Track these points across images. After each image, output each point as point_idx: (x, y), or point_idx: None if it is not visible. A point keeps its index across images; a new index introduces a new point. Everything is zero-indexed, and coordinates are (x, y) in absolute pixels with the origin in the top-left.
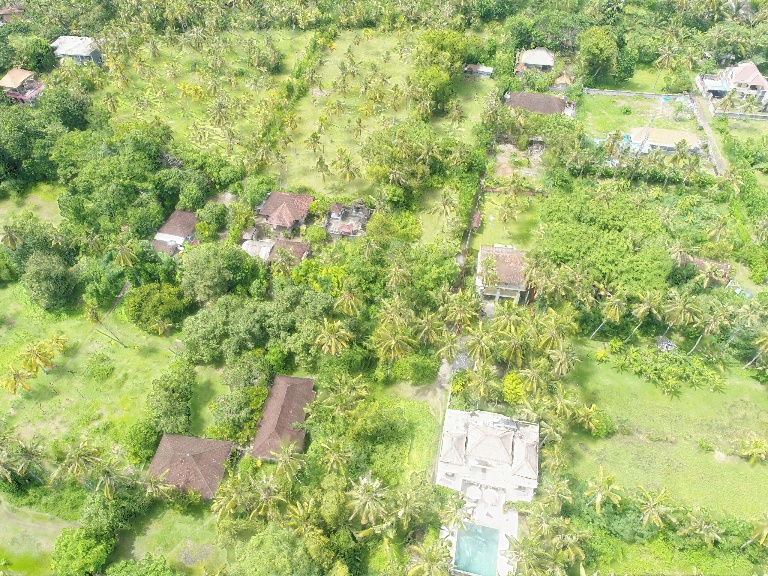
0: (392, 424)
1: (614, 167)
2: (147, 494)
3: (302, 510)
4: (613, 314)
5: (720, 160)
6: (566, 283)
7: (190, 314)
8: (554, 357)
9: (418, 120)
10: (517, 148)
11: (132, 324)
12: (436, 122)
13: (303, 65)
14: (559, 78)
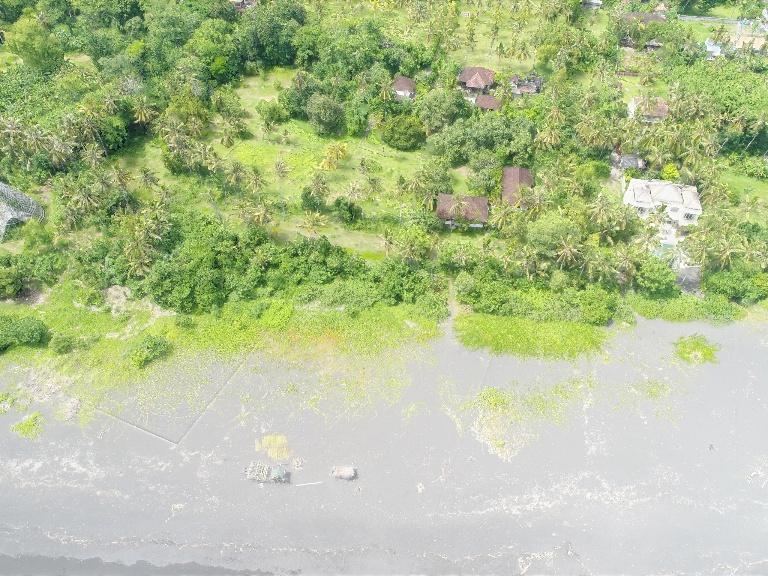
0: (594, 189)
1: (713, 60)
2: (453, 209)
3: (561, 211)
4: (738, 126)
5: None
6: (705, 106)
7: (425, 139)
8: (705, 144)
9: None
10: None
11: (383, 145)
12: None
13: None
14: (658, 6)
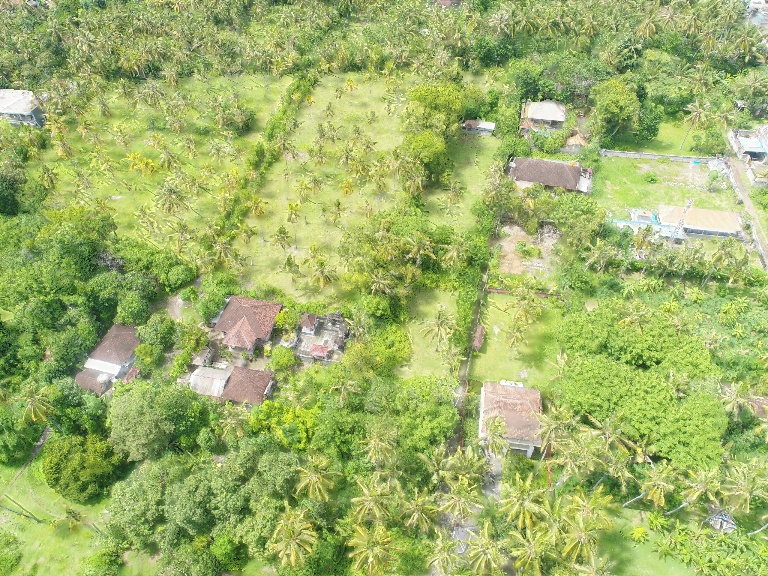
0: None
1: (642, 260)
2: None
3: None
4: (657, 499)
5: (766, 245)
6: (595, 457)
7: (123, 473)
8: (584, 575)
9: (407, 203)
10: (525, 231)
11: None
12: (429, 196)
13: (277, 121)
14: (572, 138)
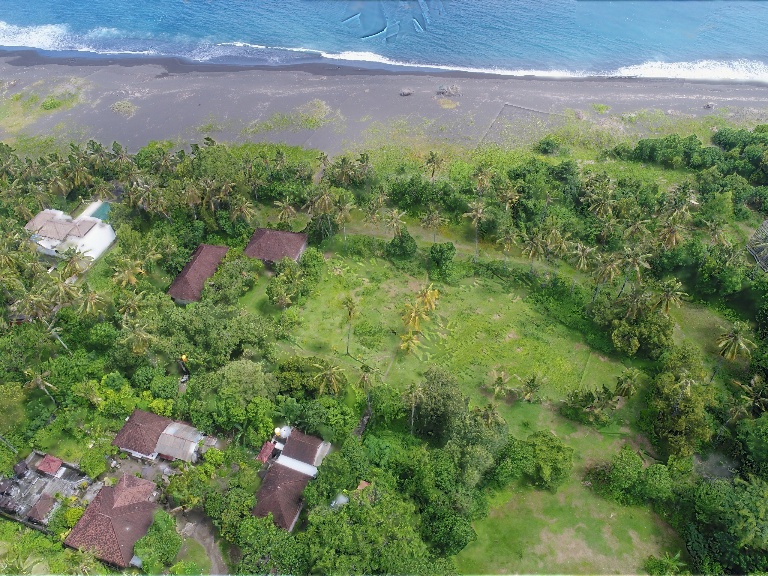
0: None
1: None
2: None
3: None
4: None
5: None
6: None
7: None
8: None
9: None
10: None
11: None
12: None
13: None
14: None
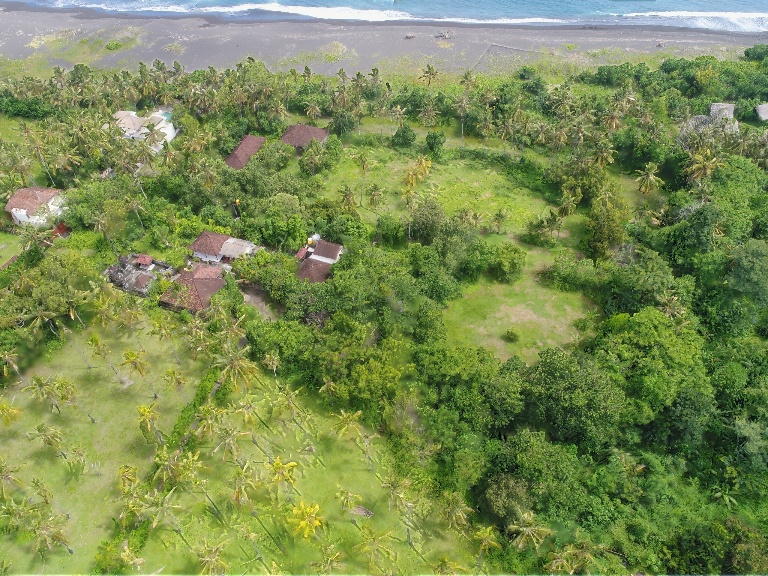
0: None
1: None
2: (318, 107)
3: None
4: None
5: None
6: None
7: None
8: None
9: None
10: None
11: None
12: None
13: None
14: None
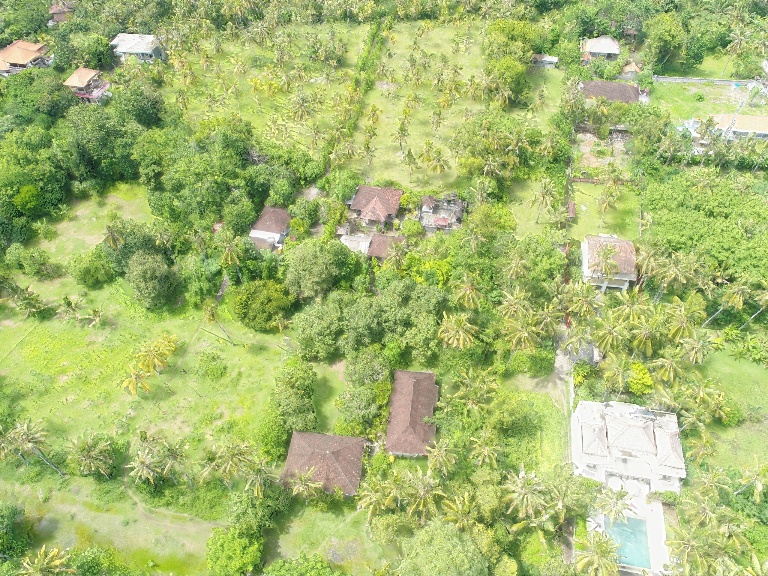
0: (524, 417)
1: (700, 154)
2: (296, 492)
3: (461, 505)
4: (737, 301)
5: None
6: (688, 271)
7: (295, 311)
8: (688, 346)
9: (500, 111)
10: (596, 137)
11: (237, 322)
12: (510, 113)
13: (365, 58)
14: (628, 66)
